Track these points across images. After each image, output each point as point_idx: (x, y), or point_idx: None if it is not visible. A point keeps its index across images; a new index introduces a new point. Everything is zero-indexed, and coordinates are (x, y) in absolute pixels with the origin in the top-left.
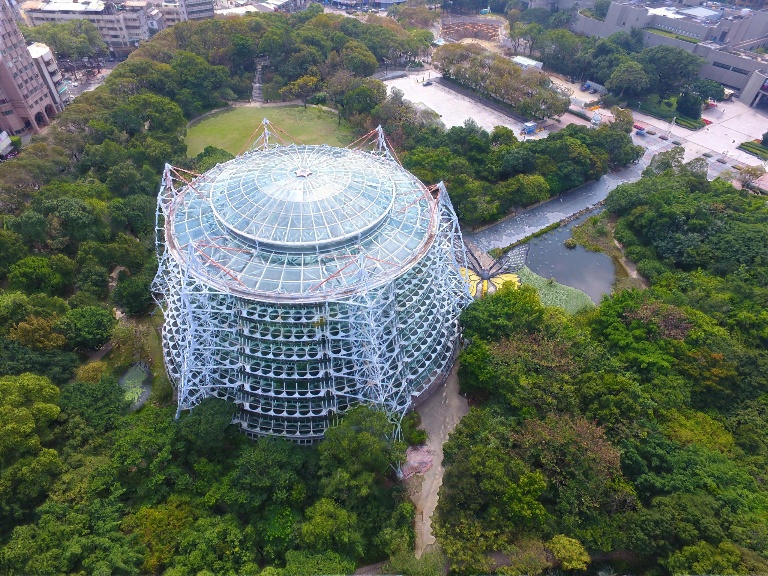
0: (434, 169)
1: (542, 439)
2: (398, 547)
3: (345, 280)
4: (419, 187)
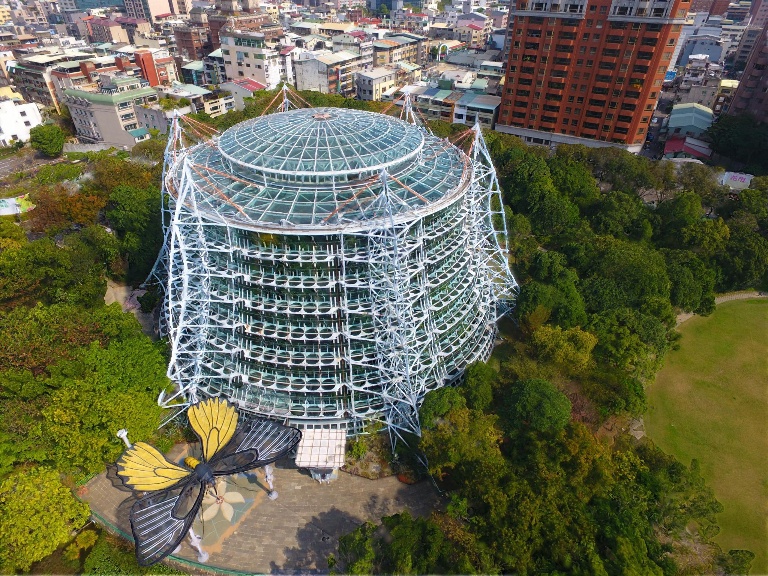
0: (563, 573)
1: (5, 289)
2: (100, 232)
3: (203, 149)
4: (266, 221)
